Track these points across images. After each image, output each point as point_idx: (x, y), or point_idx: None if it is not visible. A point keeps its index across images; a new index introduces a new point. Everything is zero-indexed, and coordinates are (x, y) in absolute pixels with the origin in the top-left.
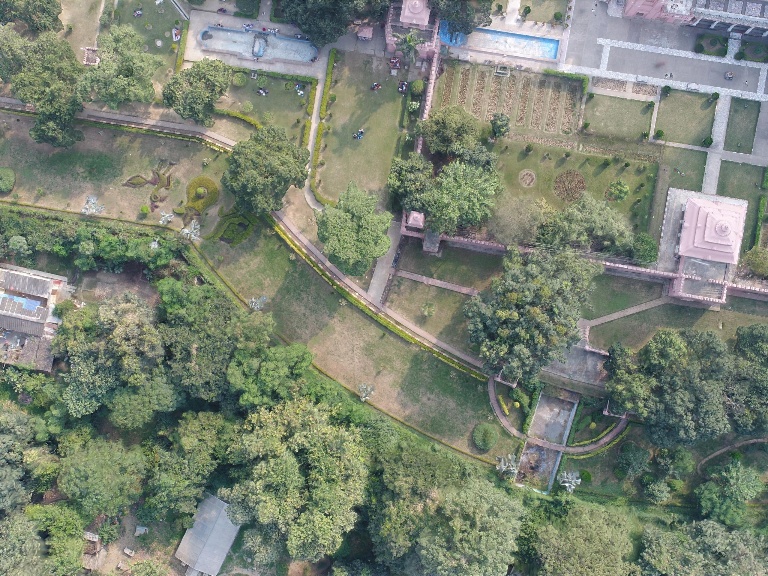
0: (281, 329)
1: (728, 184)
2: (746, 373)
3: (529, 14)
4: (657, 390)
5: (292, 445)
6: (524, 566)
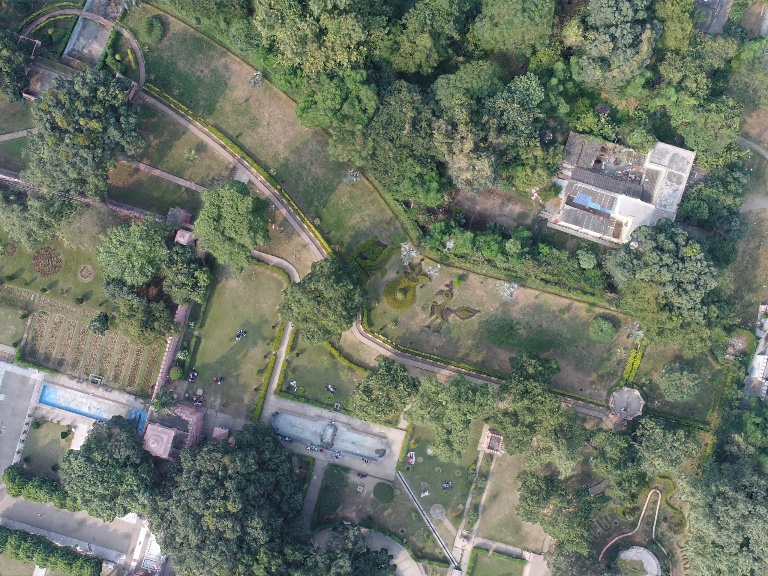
0: None
1: None
2: None
3: None
4: None
5: (313, 22)
6: None
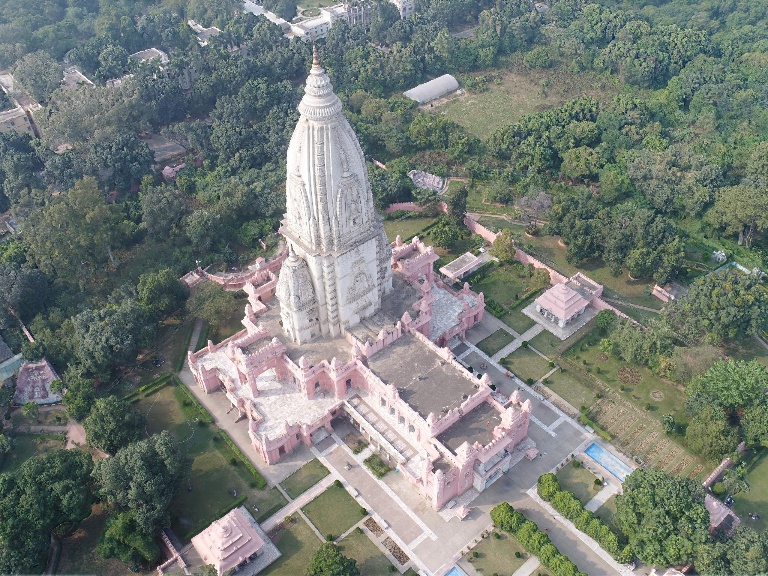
0: None
1: (526, 324)
2: None
3: None
4: None
5: None
6: (763, 247)
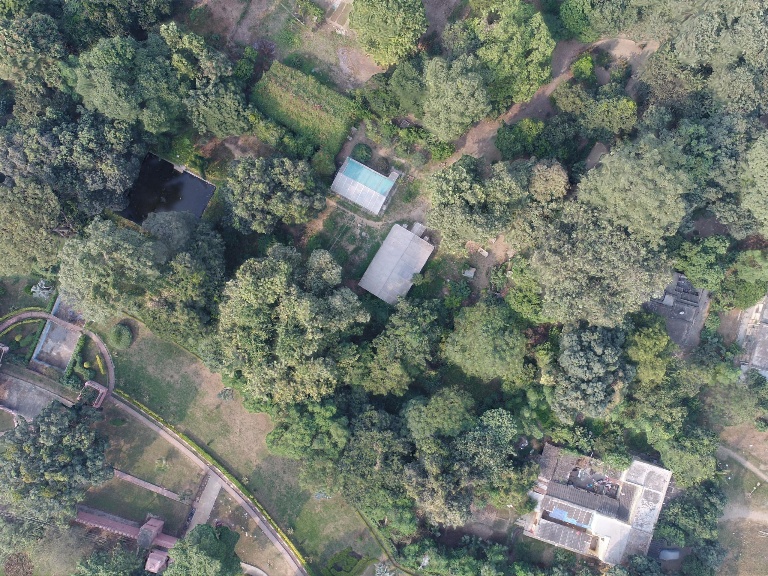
0: None
1: None
2: None
3: None
4: None
5: (280, 368)
6: None
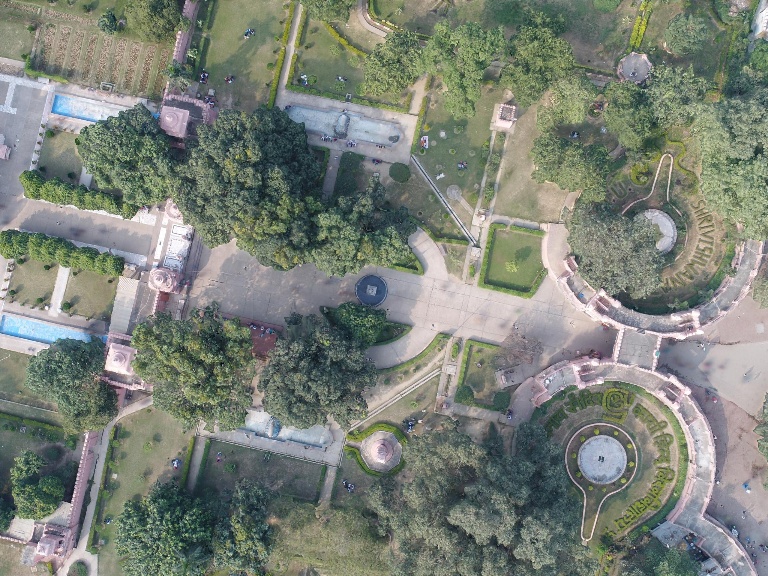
0: None
1: None
2: None
3: None
4: None
5: None
6: None
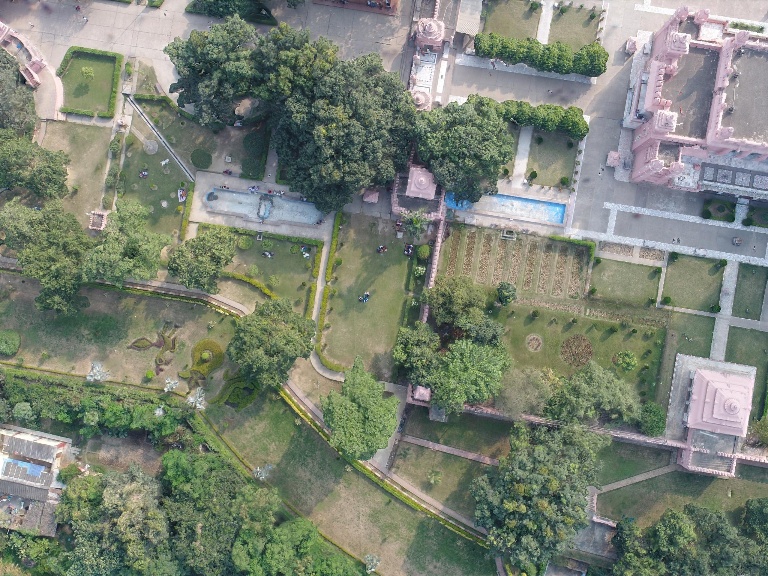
0: (286, 495)
1: (736, 350)
2: (756, 561)
3: (535, 177)
4: (666, 575)
5: None
6: None
